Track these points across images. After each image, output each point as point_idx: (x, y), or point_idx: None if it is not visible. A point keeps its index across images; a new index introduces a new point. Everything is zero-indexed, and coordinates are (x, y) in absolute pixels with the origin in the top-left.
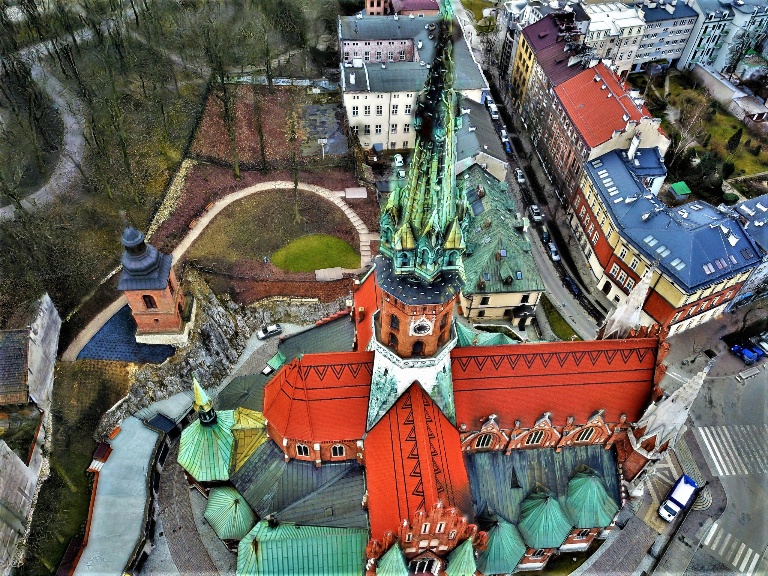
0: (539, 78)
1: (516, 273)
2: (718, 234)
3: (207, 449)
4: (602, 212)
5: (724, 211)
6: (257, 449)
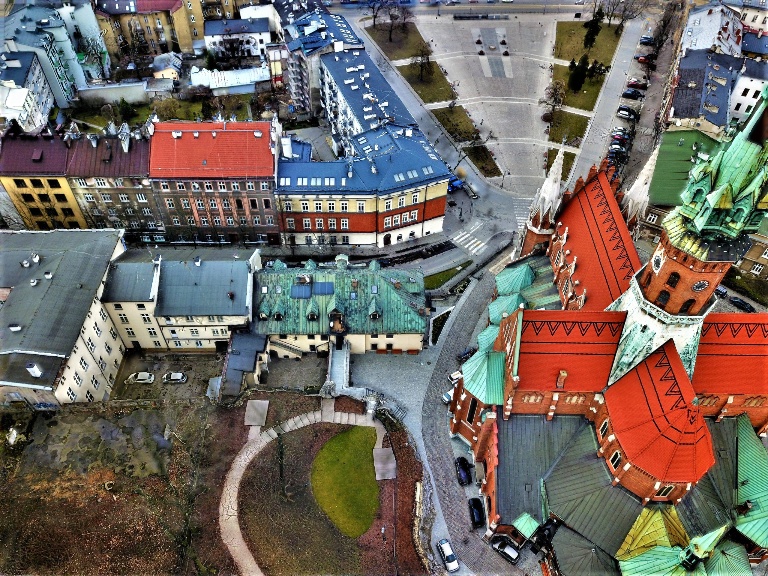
0: (103, 189)
1: (410, 281)
2: (402, 138)
3: (700, 574)
4: (338, 202)
5: (377, 126)
6: (681, 521)
